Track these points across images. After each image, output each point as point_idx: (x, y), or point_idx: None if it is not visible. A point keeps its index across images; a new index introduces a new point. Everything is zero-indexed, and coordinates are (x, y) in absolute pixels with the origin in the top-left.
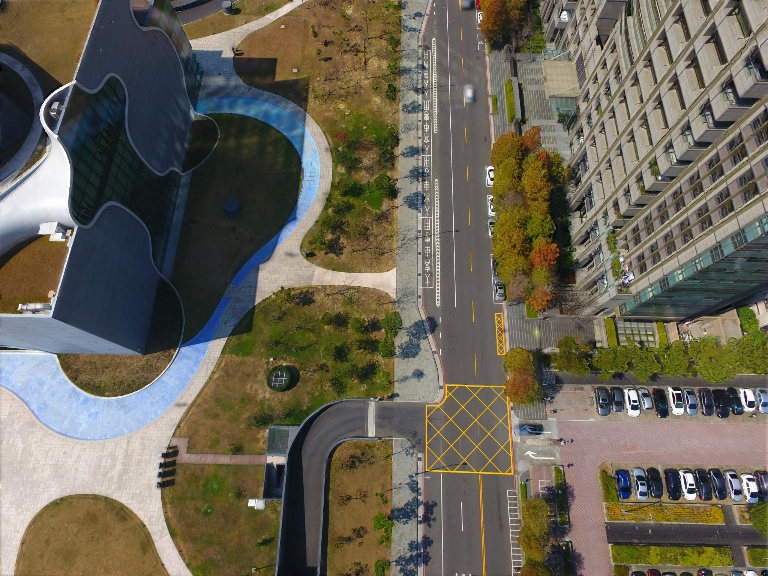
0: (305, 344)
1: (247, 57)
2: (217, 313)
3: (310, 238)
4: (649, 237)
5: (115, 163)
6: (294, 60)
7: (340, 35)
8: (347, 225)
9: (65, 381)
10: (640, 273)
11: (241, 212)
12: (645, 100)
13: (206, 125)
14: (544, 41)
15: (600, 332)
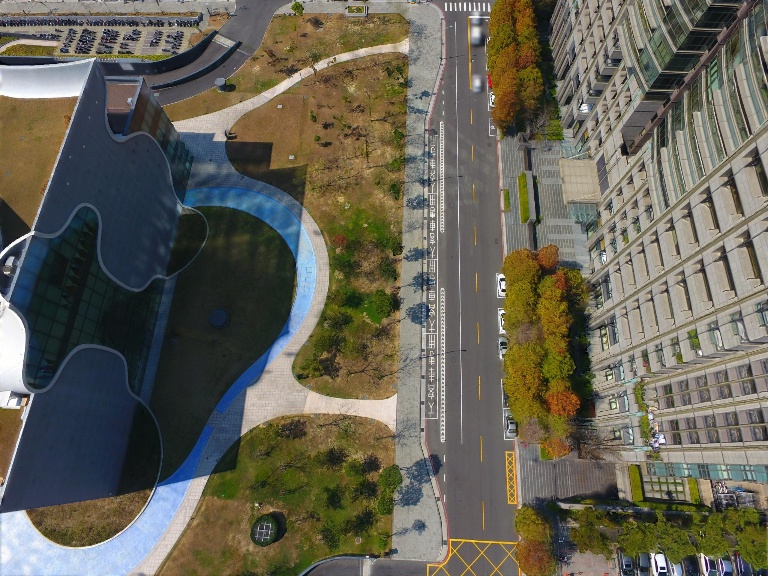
0: (294, 486)
1: (241, 141)
2: (199, 445)
3: (303, 356)
4: (685, 409)
5: (84, 301)
6: (291, 145)
7: (341, 120)
8: (344, 345)
9: (28, 526)
10: (673, 441)
11: (229, 324)
12: (683, 258)
13: (194, 220)
14: (561, 127)
15: (623, 480)
